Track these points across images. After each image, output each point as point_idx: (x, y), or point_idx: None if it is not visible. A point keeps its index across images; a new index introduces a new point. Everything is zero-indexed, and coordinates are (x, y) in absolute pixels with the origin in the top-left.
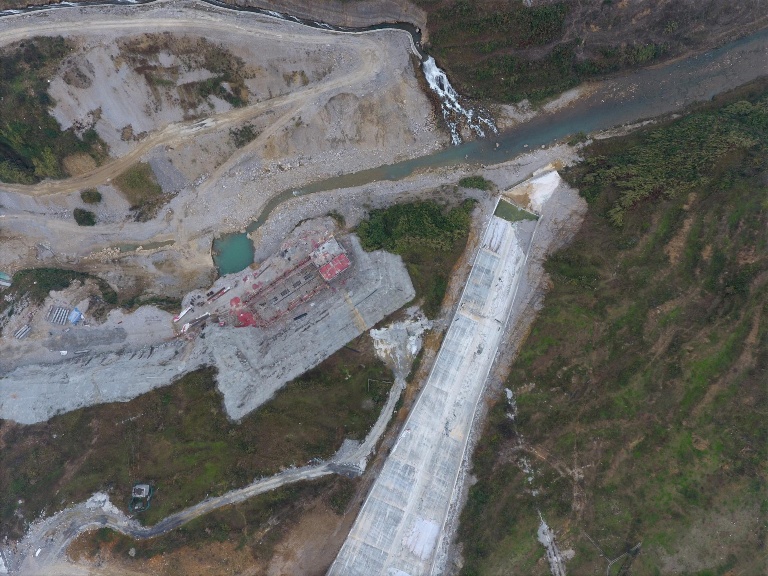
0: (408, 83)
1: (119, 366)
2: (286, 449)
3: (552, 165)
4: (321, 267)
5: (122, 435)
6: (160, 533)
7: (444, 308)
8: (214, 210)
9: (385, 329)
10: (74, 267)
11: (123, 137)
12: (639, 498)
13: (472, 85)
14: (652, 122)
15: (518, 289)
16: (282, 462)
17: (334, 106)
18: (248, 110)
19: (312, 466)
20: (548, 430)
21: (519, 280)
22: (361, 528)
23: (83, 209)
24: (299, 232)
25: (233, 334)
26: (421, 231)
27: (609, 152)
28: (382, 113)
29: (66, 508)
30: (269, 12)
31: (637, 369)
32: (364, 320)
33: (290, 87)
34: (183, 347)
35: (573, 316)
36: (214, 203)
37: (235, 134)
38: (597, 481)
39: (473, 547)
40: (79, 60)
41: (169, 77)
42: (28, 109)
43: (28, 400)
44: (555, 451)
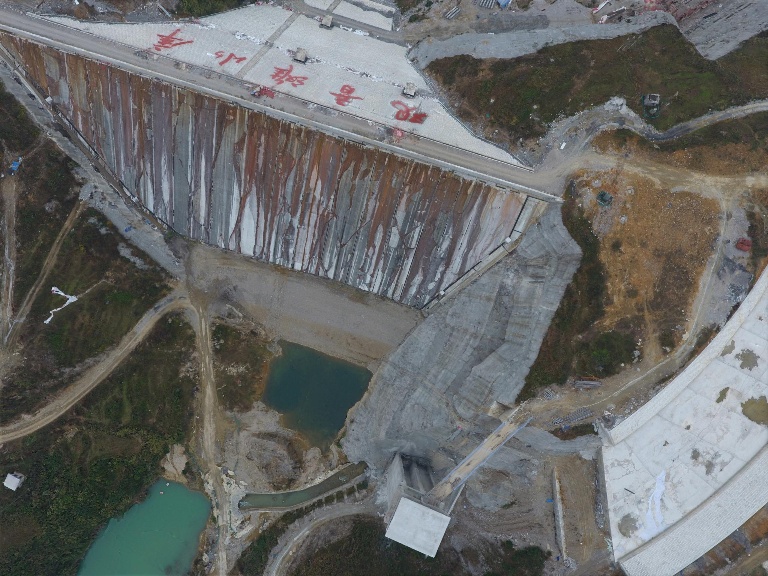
0: None
1: None
2: (767, 83)
3: None
4: None
5: (616, 62)
6: (671, 138)
7: None
8: None
9: None
10: None
11: None
12: None
13: None
14: None
15: None
16: None
17: None
18: None
19: None
20: None
21: None
22: None
23: None
24: None
25: (668, 13)
26: None
27: None
28: None
29: (585, 110)
30: None
31: None
32: None
33: None
34: None
35: None
36: None
37: None
38: None
39: None
40: None
41: None
42: None
43: (502, 44)
44: None
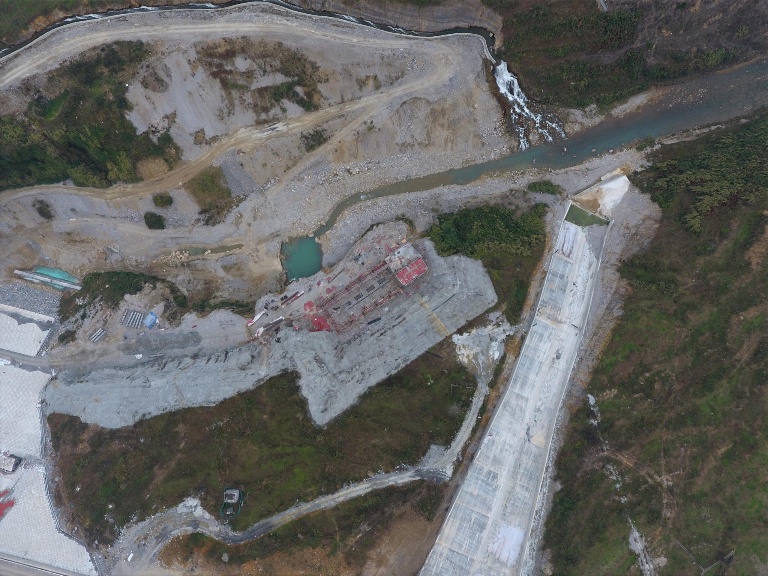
0: (480, 87)
1: (199, 370)
2: (373, 454)
3: (620, 170)
4: (398, 272)
5: (209, 440)
6: (251, 538)
7: (523, 313)
8: (283, 214)
9: (467, 334)
10: (143, 270)
11: (196, 141)
12: (729, 506)
13: (542, 89)
14: (720, 127)
15: (594, 294)
16: (370, 468)
17: (405, 110)
18: (320, 114)
19: (400, 472)
20: (634, 436)
21: (594, 285)
22: (447, 534)
23: (154, 213)
24: (372, 236)
25: (311, 338)
26: (497, 236)
27: (678, 157)
28: (454, 117)
29: (157, 513)
30: (344, 16)
31: (722, 375)
32: (445, 325)
33: (362, 91)
34: (259, 351)
35: (654, 322)
36: (283, 207)
37: (306, 138)
38: (686, 488)
39: (562, 554)
40: (157, 64)
41: (244, 81)
42: (106, 113)
43: (111, 404)
44: (642, 458)
